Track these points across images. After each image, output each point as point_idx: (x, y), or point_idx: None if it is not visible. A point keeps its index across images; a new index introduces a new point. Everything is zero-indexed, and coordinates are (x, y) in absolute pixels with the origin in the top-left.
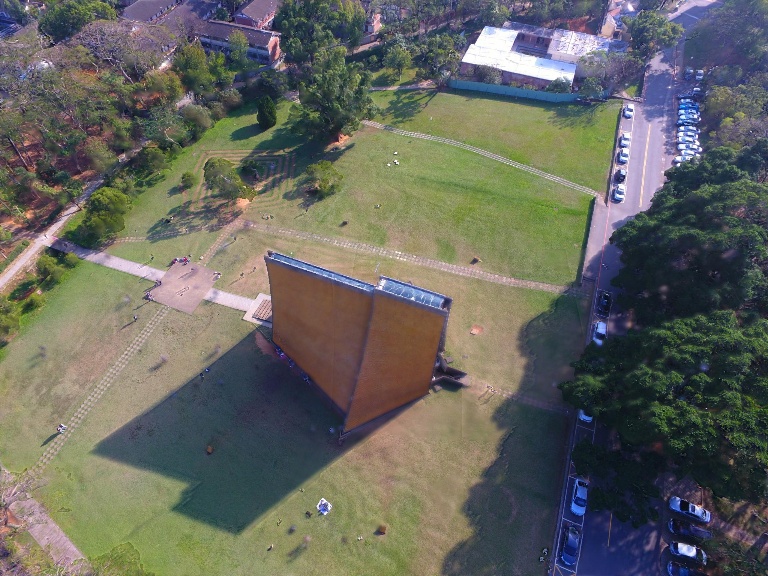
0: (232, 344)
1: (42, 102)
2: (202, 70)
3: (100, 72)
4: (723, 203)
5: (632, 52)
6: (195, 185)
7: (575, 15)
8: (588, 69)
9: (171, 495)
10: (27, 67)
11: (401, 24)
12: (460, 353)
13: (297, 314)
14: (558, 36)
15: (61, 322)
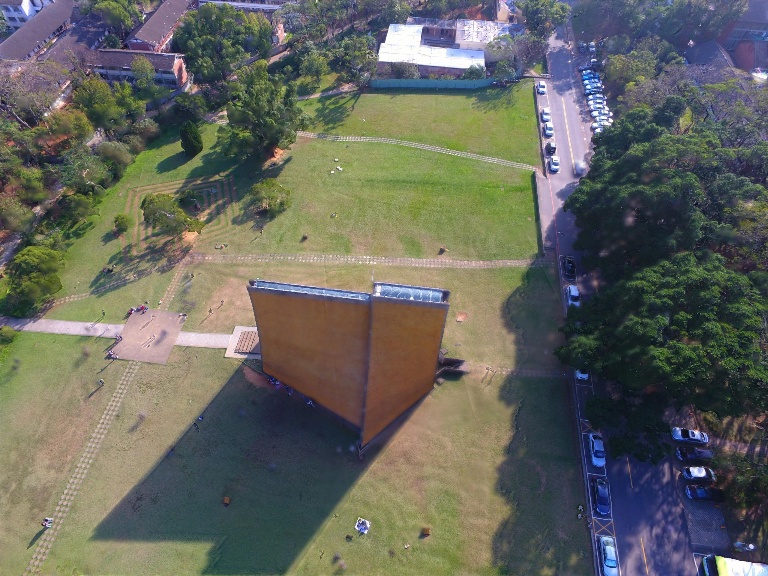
0: (220, 385)
1: None
2: (110, 103)
3: None
4: (657, 158)
5: (531, 33)
6: (131, 227)
7: (470, 5)
8: (497, 54)
9: (197, 559)
10: None
11: (308, 31)
12: (452, 342)
13: (289, 339)
14: (461, 26)
15: (13, 406)
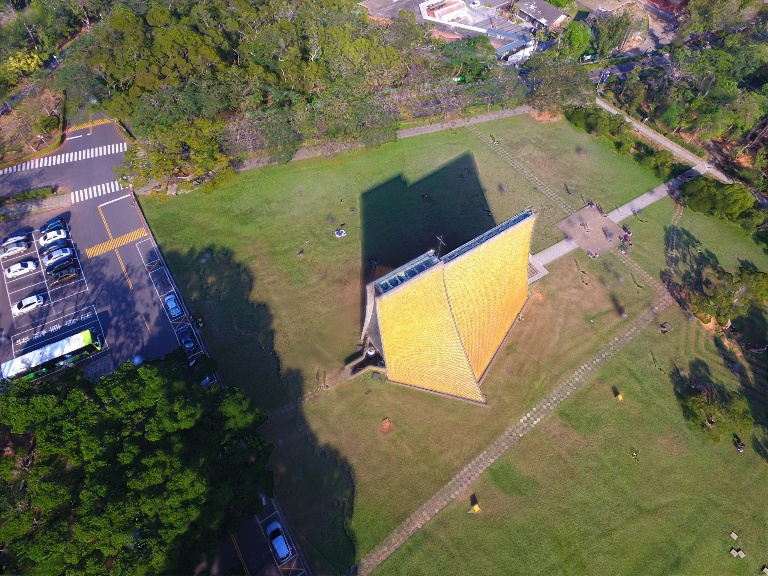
0: None
1: None
2: None
3: None
4: None
5: None
6: None
7: None
8: None
9: (411, 173)
10: None
11: None
12: (375, 391)
13: None
14: None
15: (593, 158)
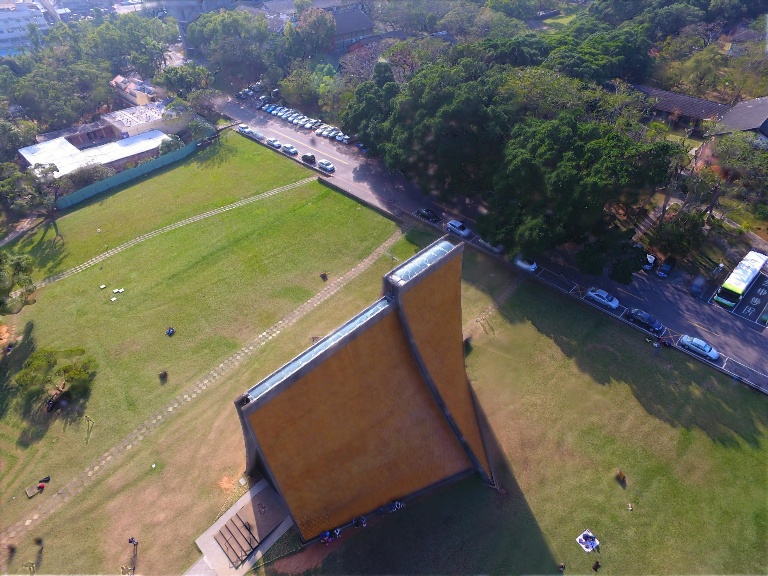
0: None
1: None
2: None
3: None
4: None
5: None
6: None
7: (96, 106)
8: (177, 122)
9: None
10: None
11: None
12: None
13: (322, 449)
14: (111, 119)
15: None
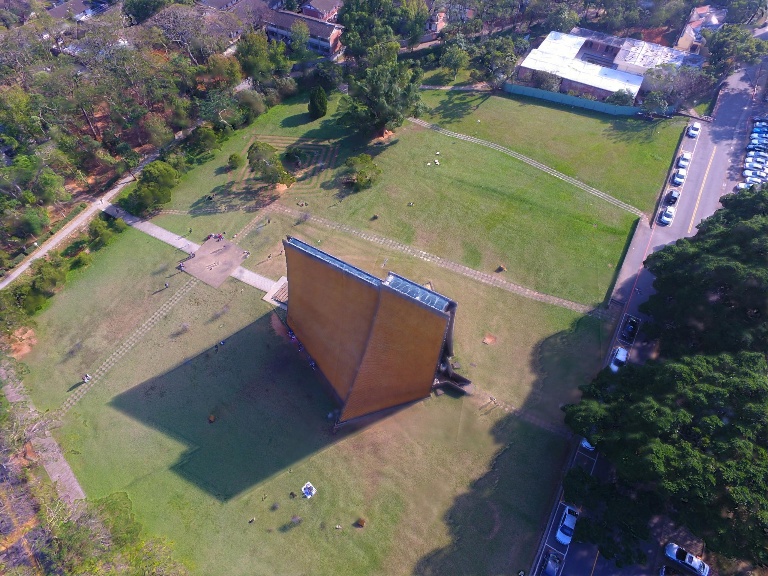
0: (249, 321)
1: (113, 77)
2: (262, 57)
3: (169, 53)
4: None
5: (707, 67)
6: (241, 167)
7: (651, 25)
8: (655, 82)
9: (171, 455)
10: (105, 44)
11: (464, 24)
12: (468, 360)
13: (310, 300)
14: (628, 46)
15: (102, 281)
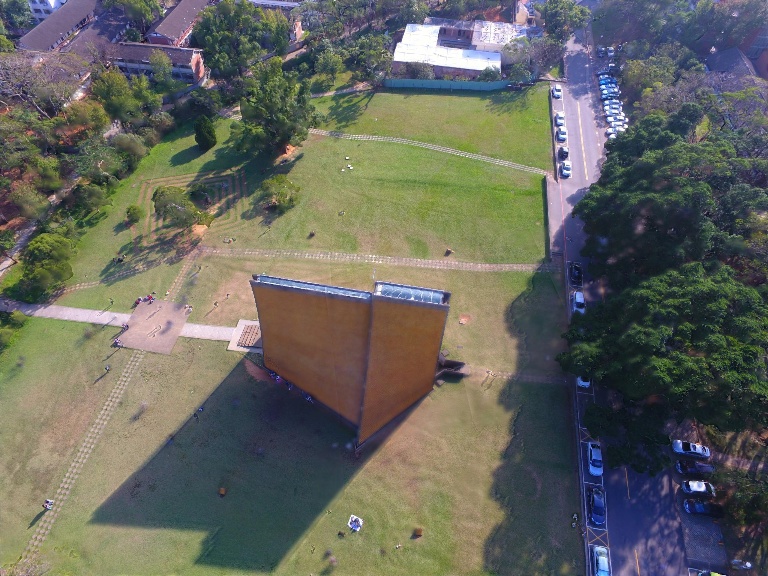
0: (222, 377)
1: None
2: (127, 96)
3: (11, 110)
4: (669, 166)
5: (549, 36)
6: (142, 218)
7: (489, 6)
8: (513, 56)
9: (191, 548)
10: None
11: (325, 29)
12: (454, 344)
13: (290, 334)
14: (478, 27)
15: (21, 389)
